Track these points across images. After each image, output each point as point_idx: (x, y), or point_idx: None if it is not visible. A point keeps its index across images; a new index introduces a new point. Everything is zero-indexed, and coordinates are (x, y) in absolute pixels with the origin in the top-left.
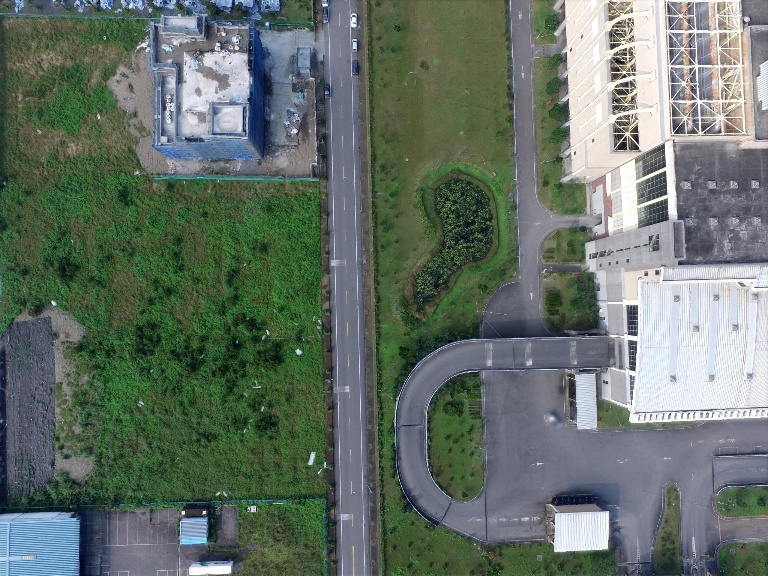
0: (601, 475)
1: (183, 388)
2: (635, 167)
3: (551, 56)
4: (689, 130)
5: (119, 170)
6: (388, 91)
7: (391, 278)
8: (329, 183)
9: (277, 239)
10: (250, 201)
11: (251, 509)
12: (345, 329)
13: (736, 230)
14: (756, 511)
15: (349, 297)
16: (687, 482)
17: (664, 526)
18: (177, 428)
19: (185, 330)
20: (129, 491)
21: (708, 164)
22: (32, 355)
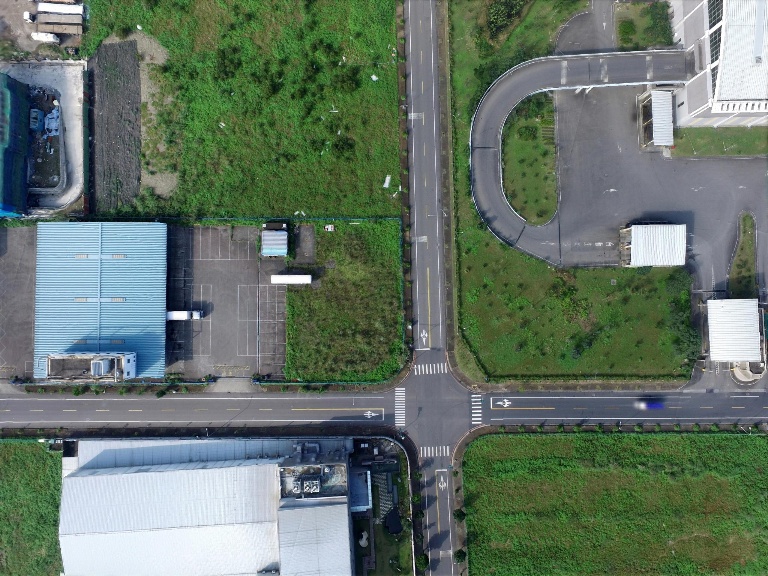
0: (675, 202)
1: (263, 110)
2: None
3: None
4: None
5: None
6: None
7: (464, 7)
8: None
9: None
10: None
11: (329, 228)
12: (419, 57)
13: None
14: None
15: (423, 26)
16: (763, 211)
17: (740, 254)
18: (257, 148)
19: (264, 55)
20: (212, 206)
21: None
22: (119, 75)
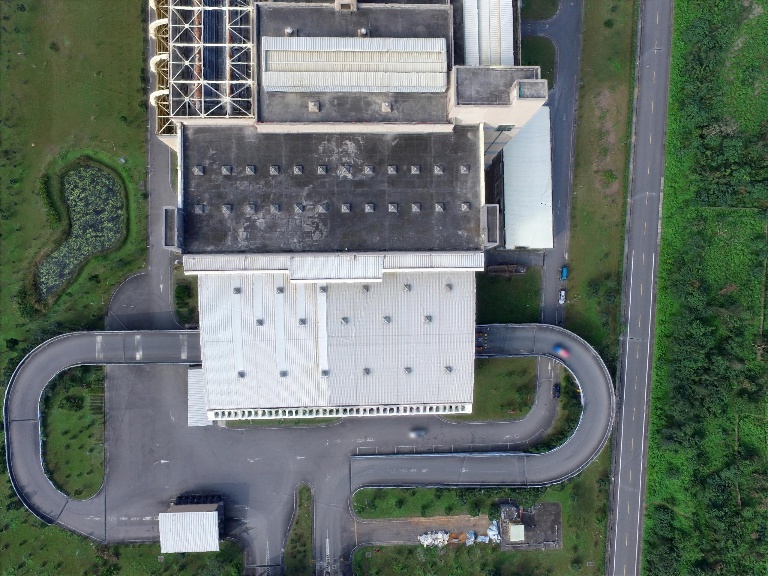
0: (230, 474)
1: None
2: None
3: None
4: (192, 112)
5: None
6: (16, 73)
7: (12, 267)
8: None
9: None
10: None
11: None
12: None
13: (253, 218)
14: (395, 513)
15: None
16: (322, 482)
17: (295, 528)
18: None
19: None
20: None
21: (224, 148)
22: None
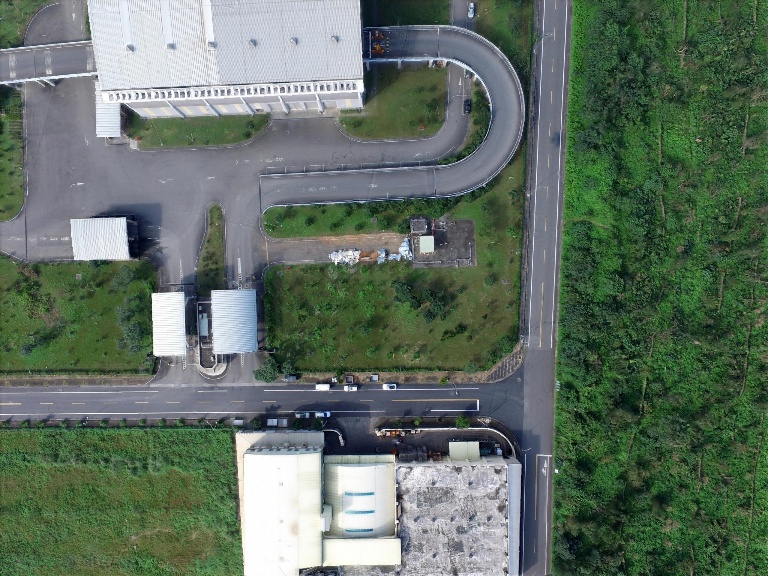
0: (143, 195)
1: None
2: None
3: None
4: None
5: None
6: None
7: None
8: None
9: None
10: None
11: None
12: None
13: None
14: (305, 232)
15: None
16: (232, 202)
17: (207, 246)
18: None
19: None
20: None
21: None
22: None
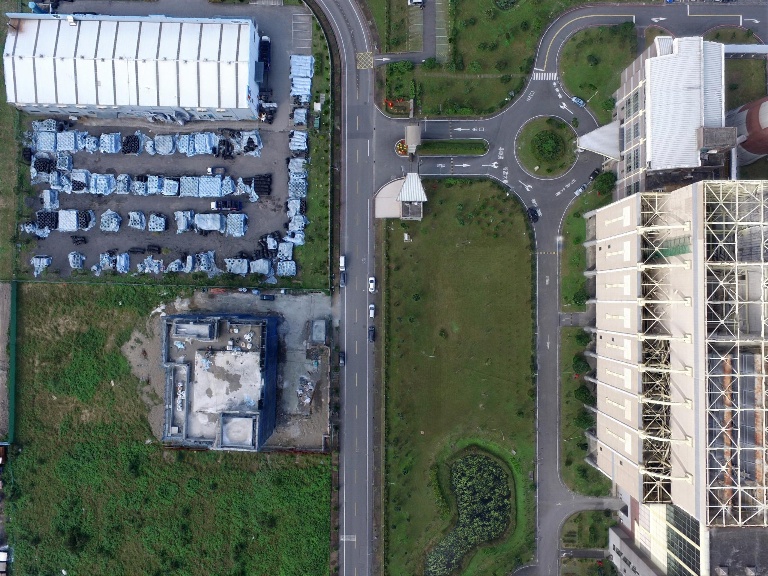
0: None
1: None
2: (666, 506)
3: (579, 325)
4: (727, 519)
5: (131, 439)
6: (405, 359)
7: (402, 557)
8: (341, 454)
9: (286, 513)
10: (260, 473)
11: None
12: None
13: None
14: None
15: (358, 574)
16: None
17: None
18: None
19: None
20: None
21: (747, 547)
22: None
